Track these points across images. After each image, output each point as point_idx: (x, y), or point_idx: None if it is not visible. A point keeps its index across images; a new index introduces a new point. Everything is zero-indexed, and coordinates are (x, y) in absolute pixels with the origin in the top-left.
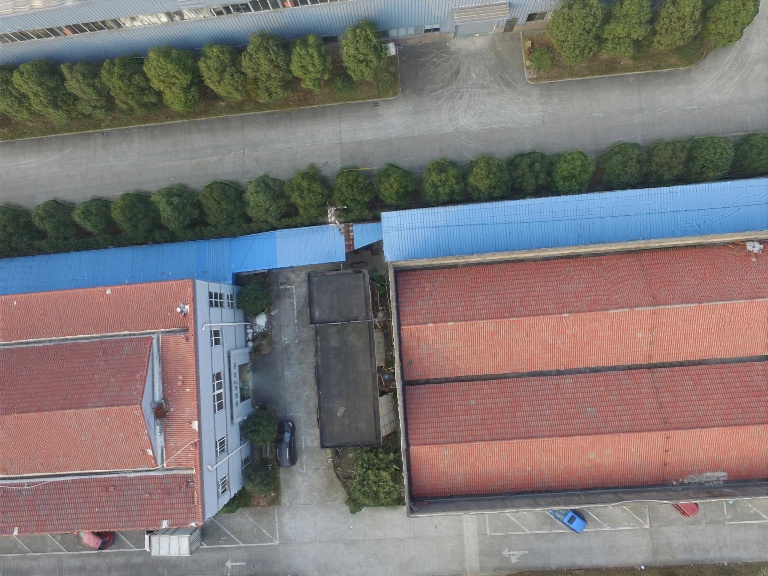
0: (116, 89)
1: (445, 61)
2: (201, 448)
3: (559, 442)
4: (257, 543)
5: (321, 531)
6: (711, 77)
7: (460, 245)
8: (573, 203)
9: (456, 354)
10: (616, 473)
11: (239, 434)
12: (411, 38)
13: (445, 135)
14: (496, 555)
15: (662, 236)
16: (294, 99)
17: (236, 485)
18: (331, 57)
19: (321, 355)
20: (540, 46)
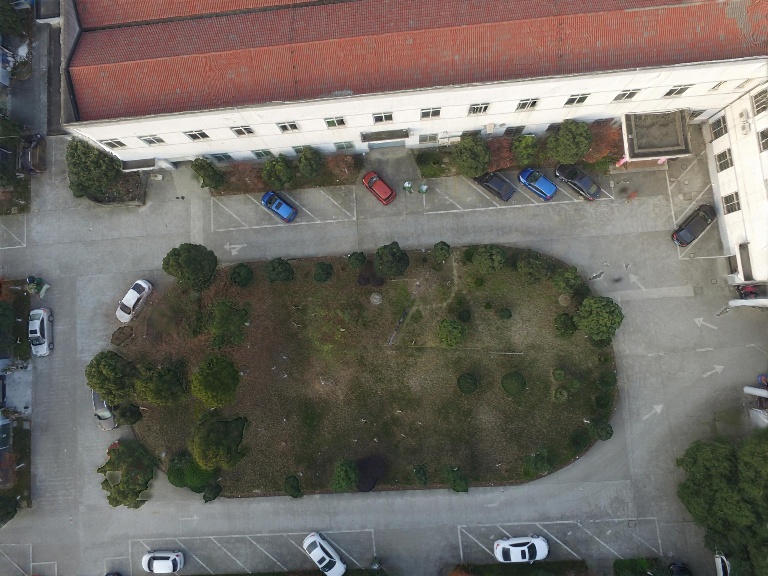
0: None
1: None
2: None
3: (199, 60)
4: (7, 246)
5: (64, 234)
6: None
7: None
8: None
9: None
10: (255, 93)
11: None
12: None
13: None
14: (218, 249)
15: None
16: None
17: None
18: None
19: (53, 56)
20: None
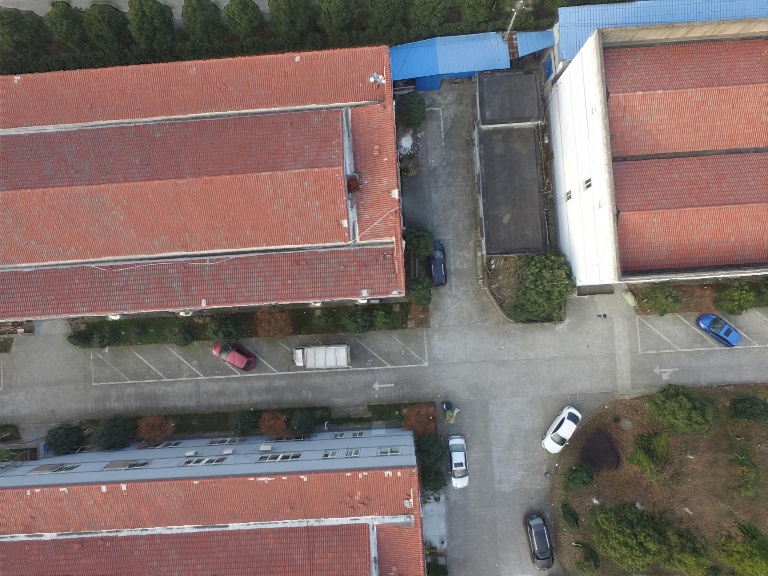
0: None
1: None
2: None
3: (767, 209)
4: (405, 365)
5: (471, 352)
6: None
7: None
8: (753, 2)
9: (659, 128)
10: None
11: None
12: None
13: None
14: (647, 373)
15: None
16: None
17: None
18: None
19: (485, 163)
20: None
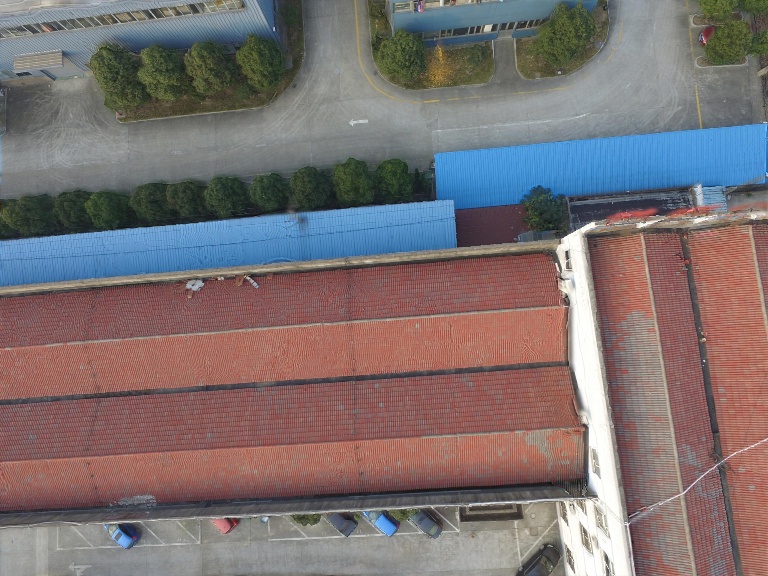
0: None
1: (47, 102)
2: None
3: None
4: None
5: None
6: (280, 117)
7: None
8: (89, 240)
9: None
10: (56, 496)
11: None
12: (11, 81)
13: (41, 172)
14: (63, 569)
15: (169, 271)
16: None
17: None
18: None
19: None
20: None
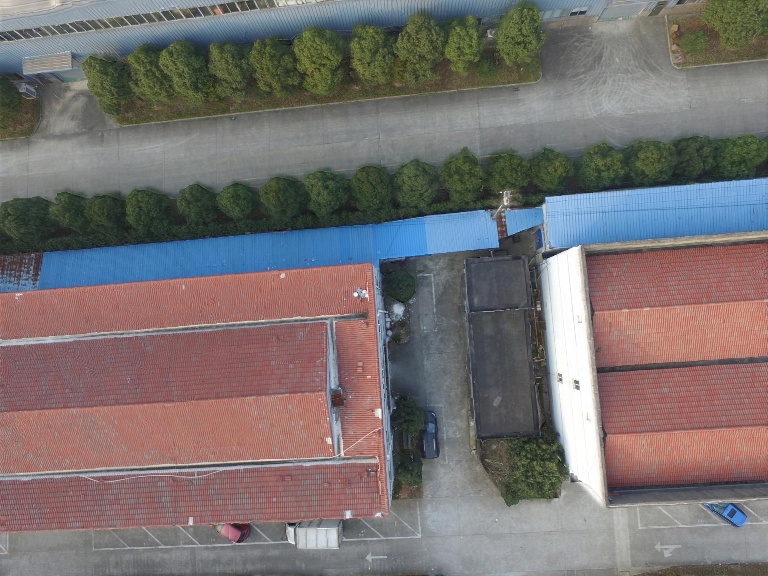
0: (263, 71)
1: (587, 45)
2: None
3: (762, 431)
4: (398, 536)
5: (465, 524)
6: None
7: (627, 231)
8: (746, 188)
9: (647, 341)
10: None
11: (390, 424)
12: (554, 21)
13: (589, 120)
14: (648, 549)
15: None
16: (431, 83)
17: (392, 476)
18: (485, 39)
19: (475, 344)
20: (687, 30)
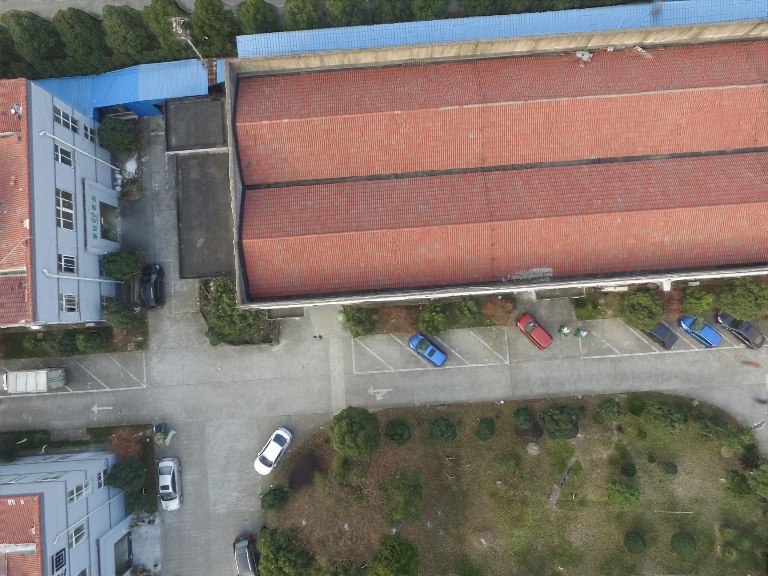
0: None
1: None
2: (34, 248)
3: (389, 235)
4: (124, 387)
5: (189, 374)
6: None
7: None
8: (426, 29)
9: (294, 155)
10: (447, 269)
11: (98, 268)
12: None
13: None
14: (361, 393)
15: None
16: None
17: (90, 313)
18: None
19: (182, 188)
20: None
